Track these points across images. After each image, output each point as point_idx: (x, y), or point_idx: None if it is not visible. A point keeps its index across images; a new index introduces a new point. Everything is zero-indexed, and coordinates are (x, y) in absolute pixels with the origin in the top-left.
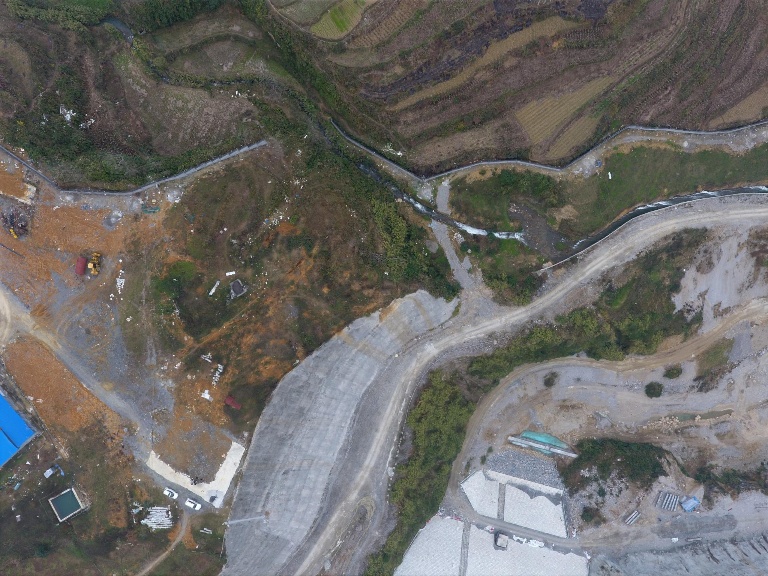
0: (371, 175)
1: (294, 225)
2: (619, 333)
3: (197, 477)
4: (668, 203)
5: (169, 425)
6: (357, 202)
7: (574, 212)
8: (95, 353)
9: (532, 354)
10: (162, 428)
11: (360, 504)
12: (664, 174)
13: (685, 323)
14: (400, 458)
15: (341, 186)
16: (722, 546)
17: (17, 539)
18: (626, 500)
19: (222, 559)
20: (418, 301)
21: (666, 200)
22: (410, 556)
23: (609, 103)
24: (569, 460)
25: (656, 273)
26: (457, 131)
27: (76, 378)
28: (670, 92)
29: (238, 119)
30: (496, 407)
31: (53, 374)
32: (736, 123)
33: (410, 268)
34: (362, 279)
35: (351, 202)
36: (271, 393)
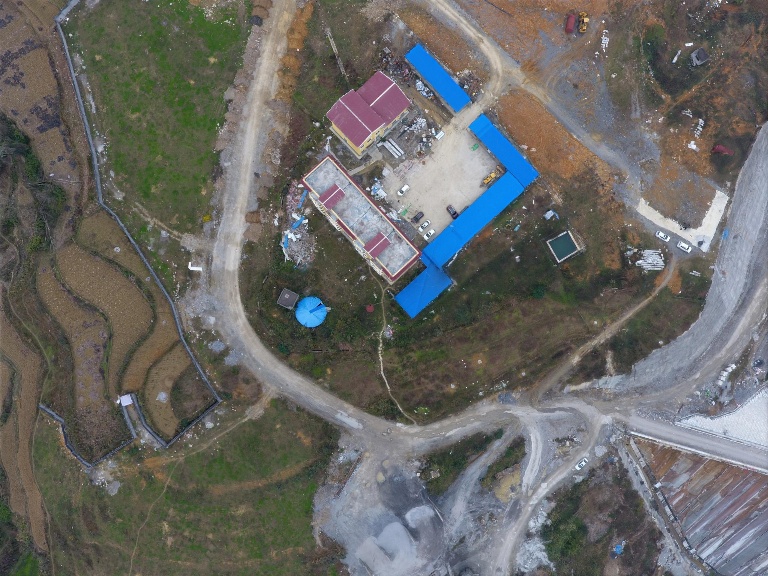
0: None
1: (739, 5)
2: None
3: (685, 223)
4: None
5: (656, 174)
6: None
7: None
8: (583, 106)
9: None
10: (650, 177)
11: None
12: None
13: None
14: None
15: None
16: None
17: (518, 278)
18: None
19: (705, 303)
20: None
21: None
22: None
23: None
24: None
25: None
26: None
27: (566, 129)
28: None
29: None
30: None
31: (545, 125)
32: None
33: None
34: None
35: None
36: (752, 145)
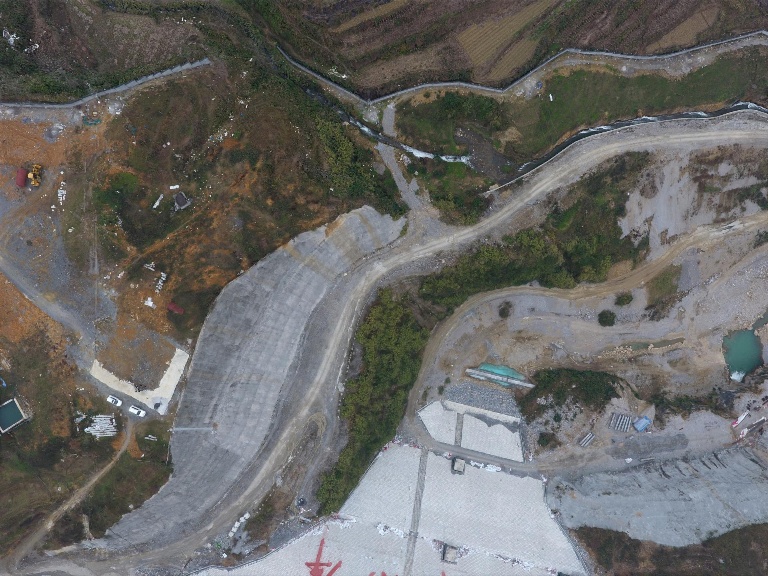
0: (317, 99)
1: (238, 140)
2: (570, 260)
3: (141, 384)
4: (610, 128)
5: (112, 334)
6: (301, 119)
7: (518, 134)
8: (37, 264)
9: (482, 276)
10: (105, 337)
11: (311, 420)
12: (604, 97)
13: (632, 248)
14: (350, 374)
15: (285, 104)
16: (674, 464)
17: None
18: (580, 423)
19: (168, 467)
20: (364, 217)
21: (608, 125)
22: (367, 480)
23: (547, 26)
24: (526, 390)
25: (601, 197)
26: (400, 54)
27: (18, 289)
28: (606, 16)
29: (184, 44)
30: (451, 336)
31: None
32: (672, 48)
33: (356, 185)
34: (306, 193)
35: (295, 118)
36: (214, 299)
